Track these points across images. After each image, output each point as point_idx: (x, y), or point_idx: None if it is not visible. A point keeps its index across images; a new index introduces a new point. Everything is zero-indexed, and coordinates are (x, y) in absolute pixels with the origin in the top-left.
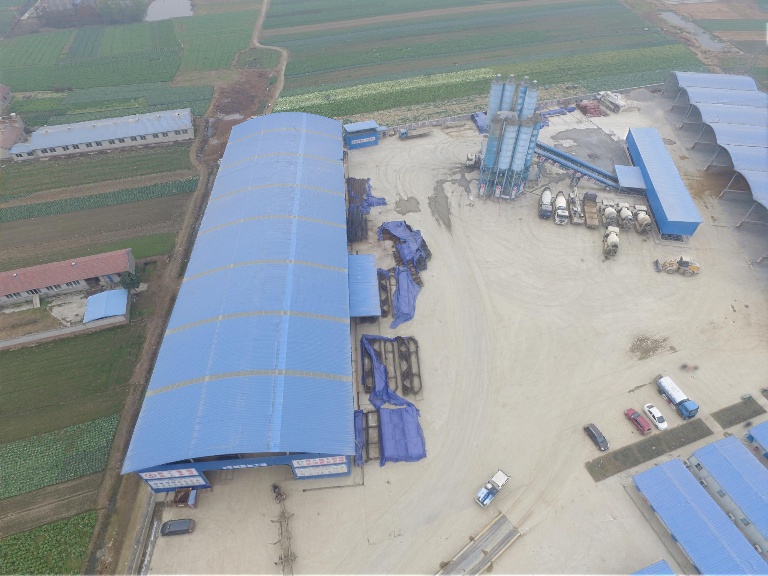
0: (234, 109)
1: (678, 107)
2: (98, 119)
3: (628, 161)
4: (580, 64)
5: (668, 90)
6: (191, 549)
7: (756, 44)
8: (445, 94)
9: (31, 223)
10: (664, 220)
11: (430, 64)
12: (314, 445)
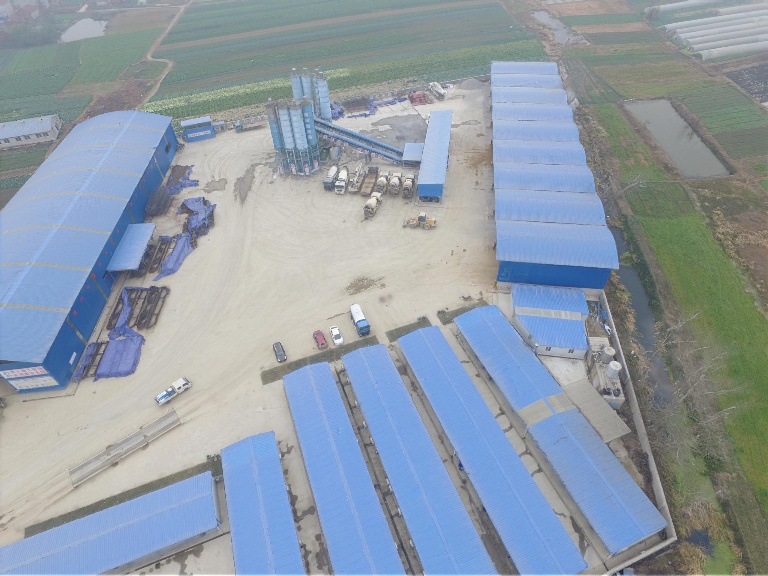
0: None
1: None
2: None
3: None
4: (431, 61)
5: None
6: None
7: (605, 35)
8: None
9: None
10: None
11: (295, 67)
12: (5, 355)
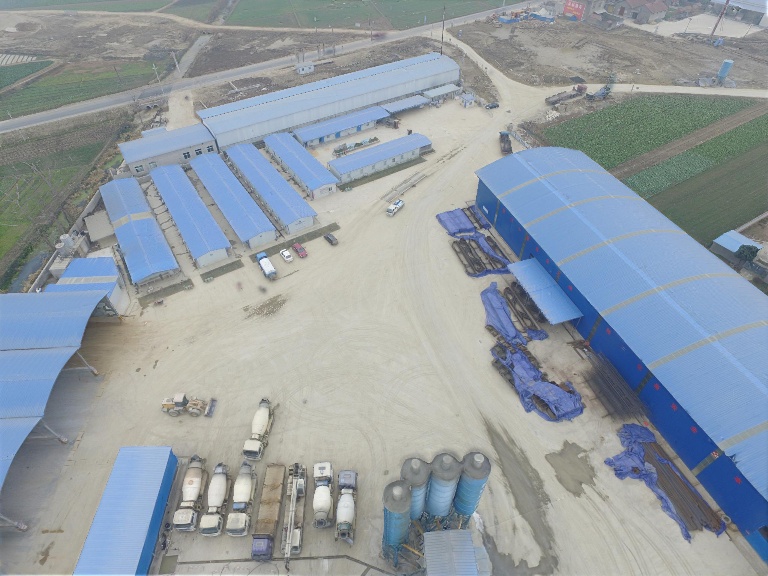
0: None
1: None
2: None
3: None
4: None
5: None
6: None
7: None
8: None
9: None
10: None
11: None
12: (497, 163)
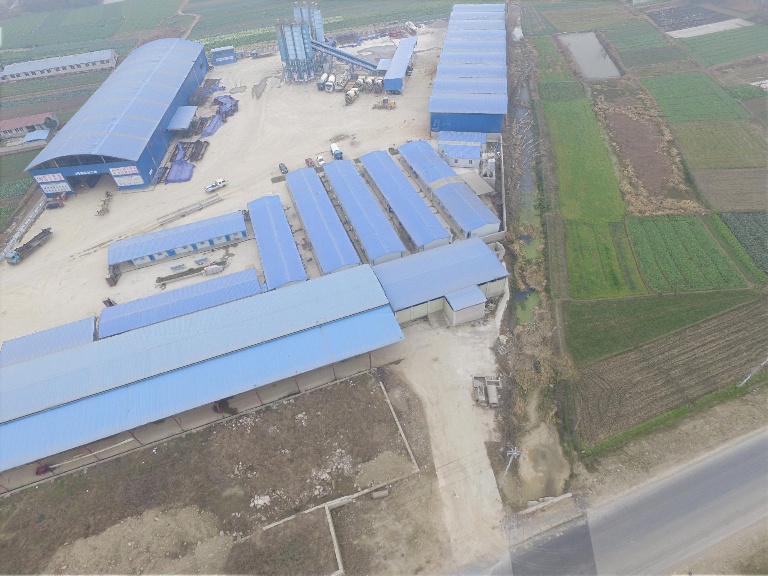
0: None
1: None
2: None
3: None
4: (411, 9)
5: None
6: (60, 212)
7: None
8: None
9: (0, 111)
10: None
11: None
12: (115, 155)
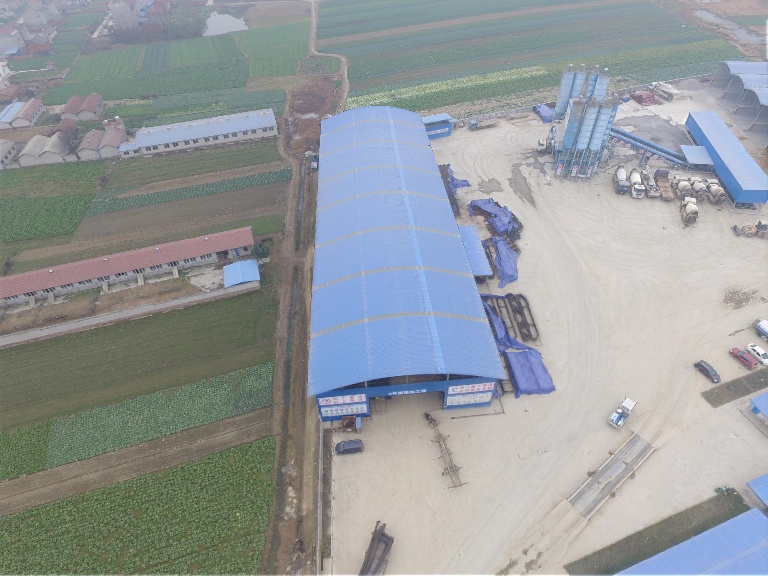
0: (308, 109)
1: (729, 94)
2: None
3: (690, 142)
4: (626, 59)
5: (717, 79)
6: (364, 464)
7: None
8: (504, 90)
9: (151, 209)
10: (738, 190)
11: (483, 64)
12: (473, 370)
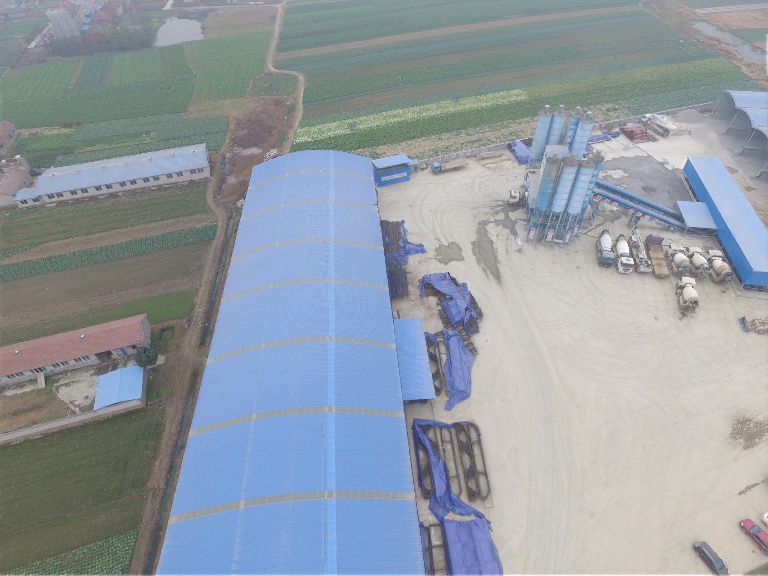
0: (251, 142)
1: (734, 130)
2: (108, 158)
3: (688, 194)
4: (617, 82)
5: (719, 110)
6: None
7: None
8: (476, 120)
9: (36, 282)
10: (747, 269)
11: (456, 86)
12: None
